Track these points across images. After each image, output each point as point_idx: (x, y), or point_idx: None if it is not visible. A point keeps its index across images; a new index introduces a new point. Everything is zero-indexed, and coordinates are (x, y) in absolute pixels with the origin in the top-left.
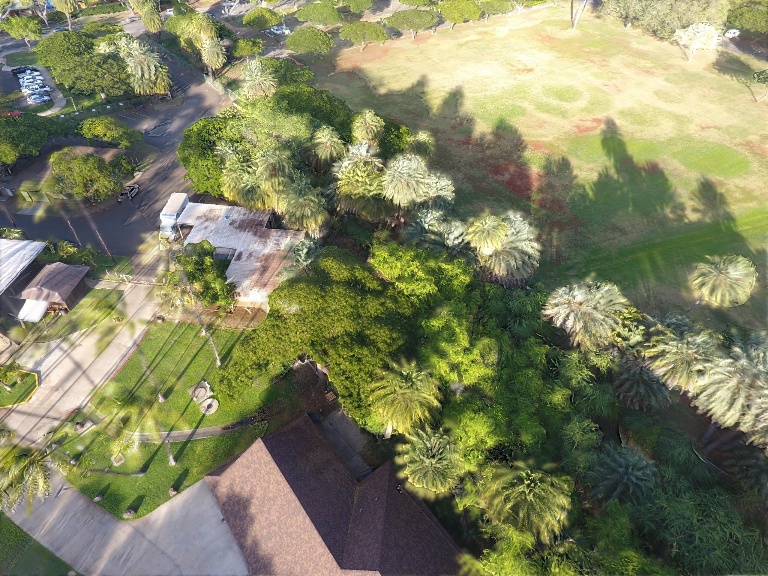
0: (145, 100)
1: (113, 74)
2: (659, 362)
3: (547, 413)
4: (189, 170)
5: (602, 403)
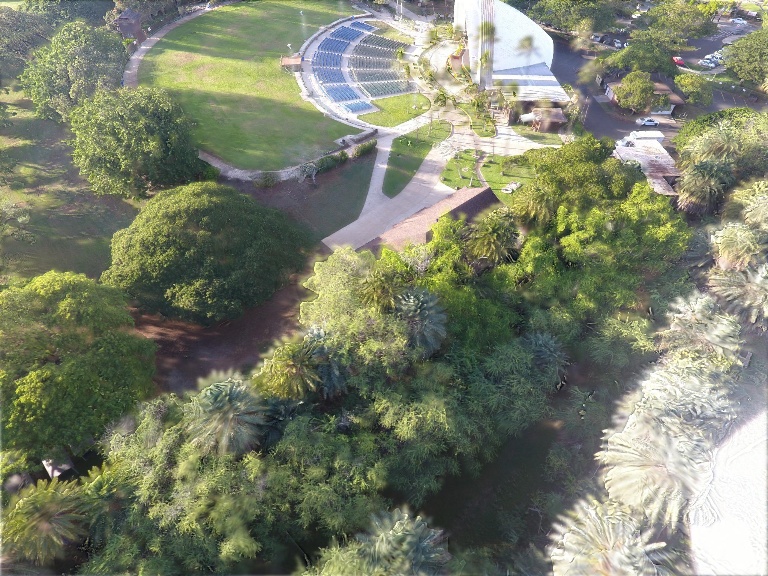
0: (766, 98)
1: (762, 65)
2: (663, 371)
3: (567, 299)
4: (684, 124)
5: (602, 348)
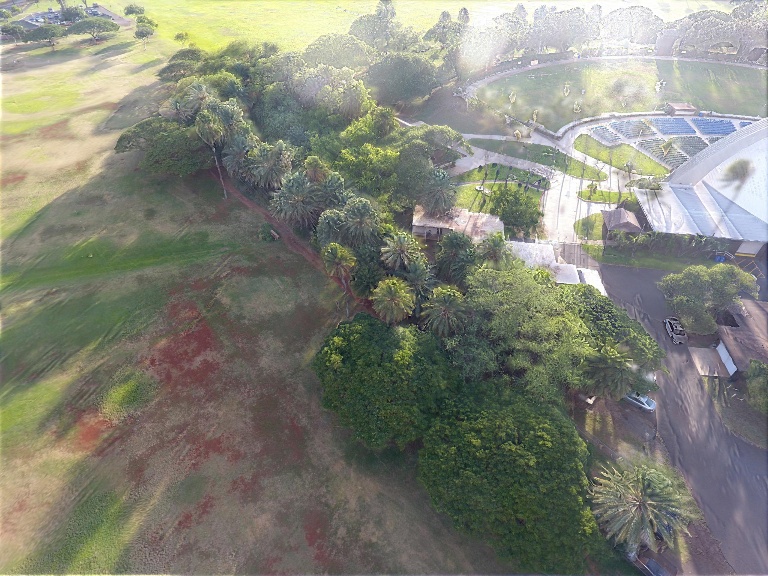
0: None
1: None
2: None
3: None
4: None
5: None
